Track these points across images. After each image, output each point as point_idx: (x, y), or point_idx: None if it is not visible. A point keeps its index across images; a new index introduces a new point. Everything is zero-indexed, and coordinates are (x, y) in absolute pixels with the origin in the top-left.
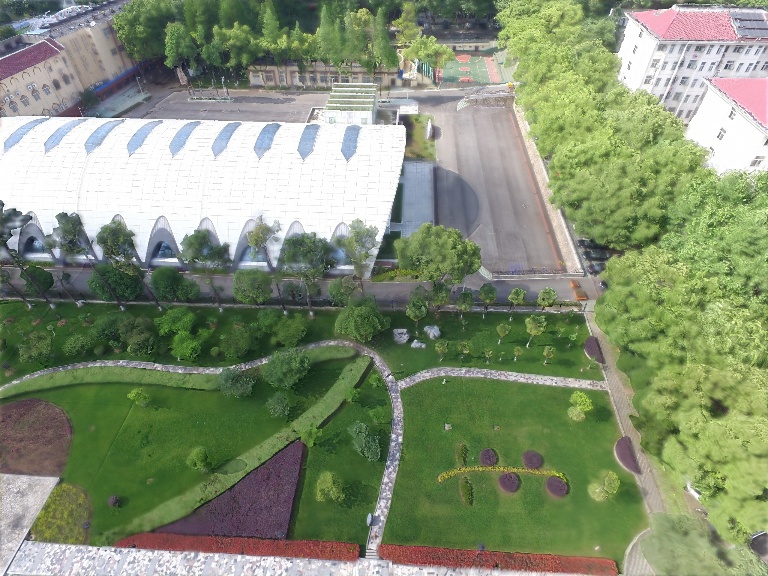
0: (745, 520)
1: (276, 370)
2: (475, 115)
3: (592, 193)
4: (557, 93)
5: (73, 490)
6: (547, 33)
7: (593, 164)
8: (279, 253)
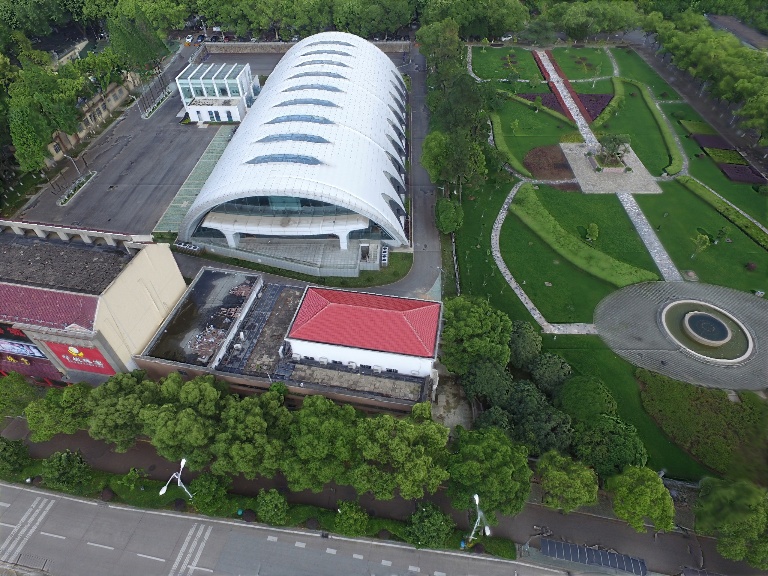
0: (523, 20)
1: (491, 90)
2: (218, 64)
3: (390, 7)
4: (286, 1)
5: (562, 138)
6: (156, 3)
7: (364, 5)
8: (402, 102)
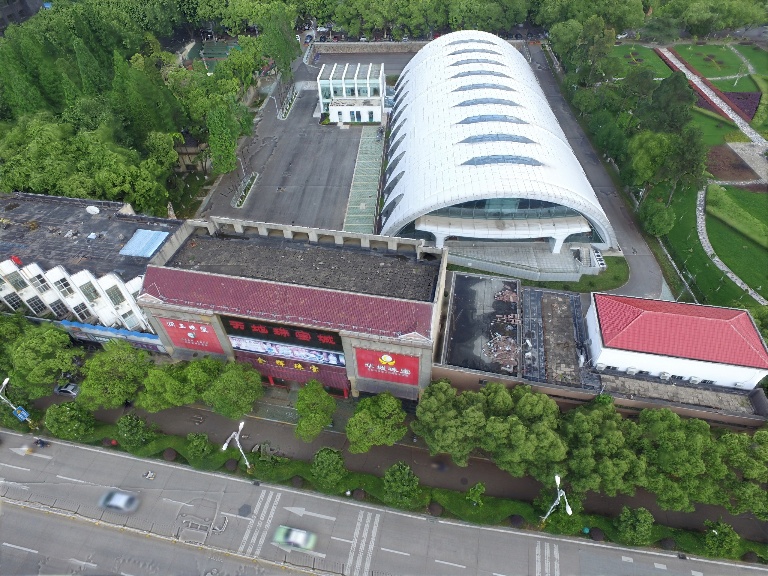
0: None
1: None
2: (332, 64)
3: (508, 5)
4: None
5: (726, 137)
6: None
7: None
8: None
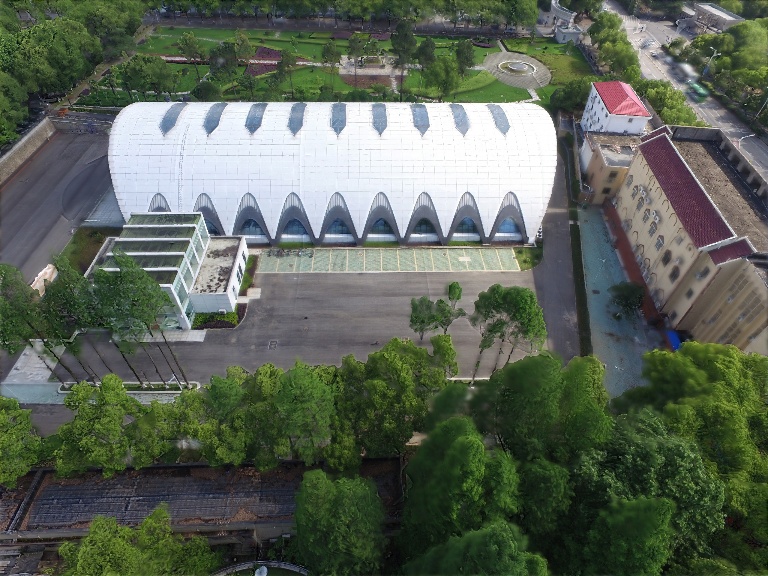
0: None
1: None
2: None
3: (5, 84)
4: None
5: None
6: None
7: None
8: None
